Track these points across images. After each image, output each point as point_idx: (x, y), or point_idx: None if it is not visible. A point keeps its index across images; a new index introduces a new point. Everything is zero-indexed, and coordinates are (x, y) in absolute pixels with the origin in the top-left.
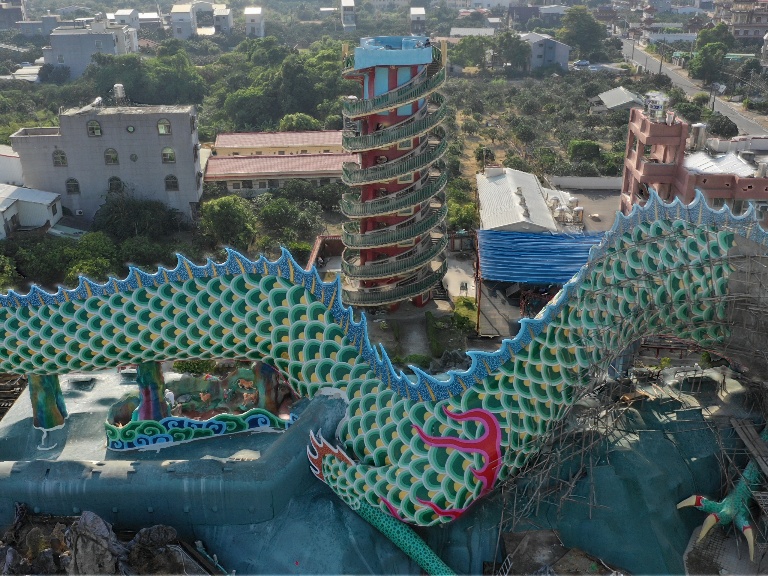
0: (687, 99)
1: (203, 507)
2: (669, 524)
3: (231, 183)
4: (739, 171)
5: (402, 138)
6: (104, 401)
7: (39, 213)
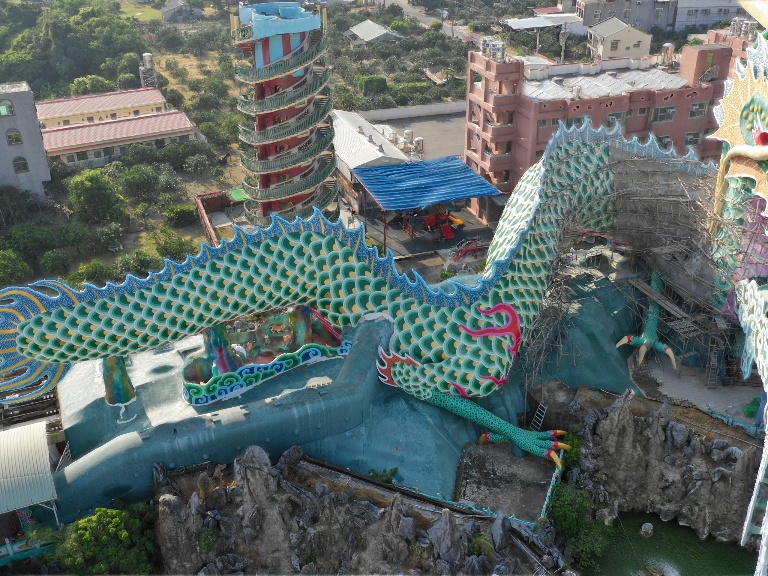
0: (423, 26)
1: (310, 427)
2: (618, 359)
3: (65, 156)
4: (562, 95)
5: (304, 97)
6: (158, 370)
7: None
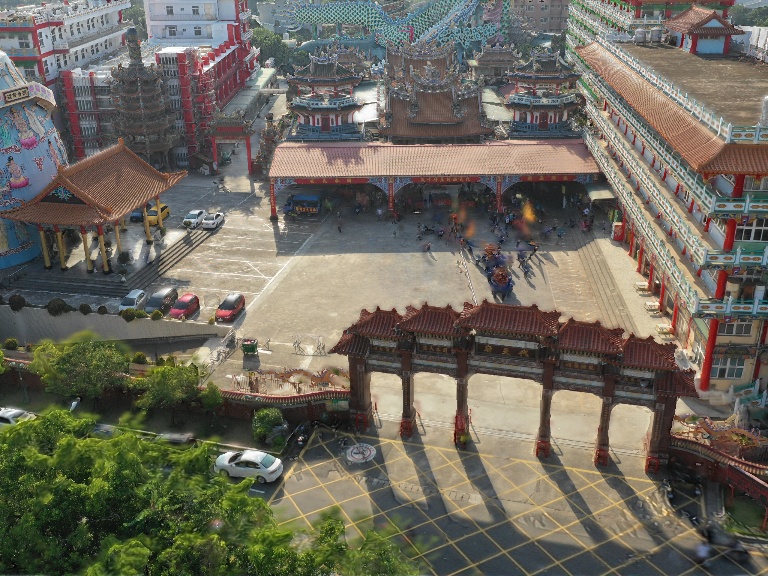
0: None
1: None
2: None
3: None
4: None
5: None
6: None
7: (270, 29)
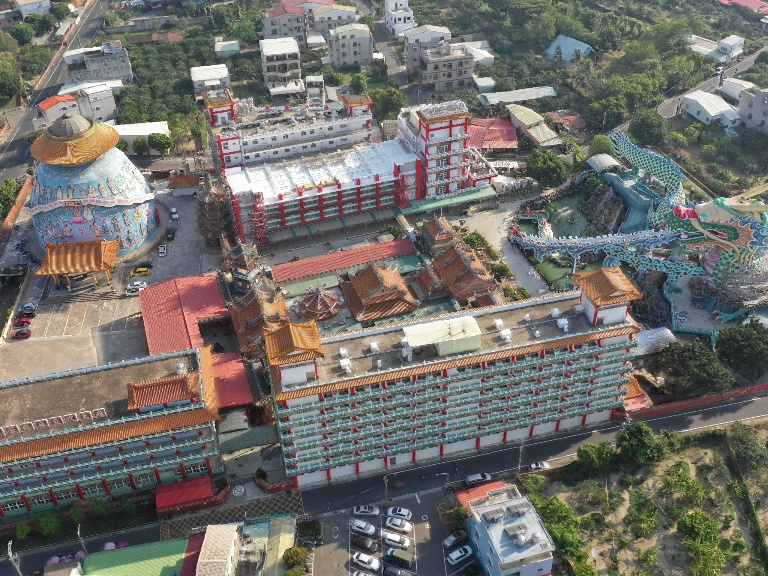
0: None
1: None
2: None
3: None
4: None
5: None
6: None
7: (727, 121)
